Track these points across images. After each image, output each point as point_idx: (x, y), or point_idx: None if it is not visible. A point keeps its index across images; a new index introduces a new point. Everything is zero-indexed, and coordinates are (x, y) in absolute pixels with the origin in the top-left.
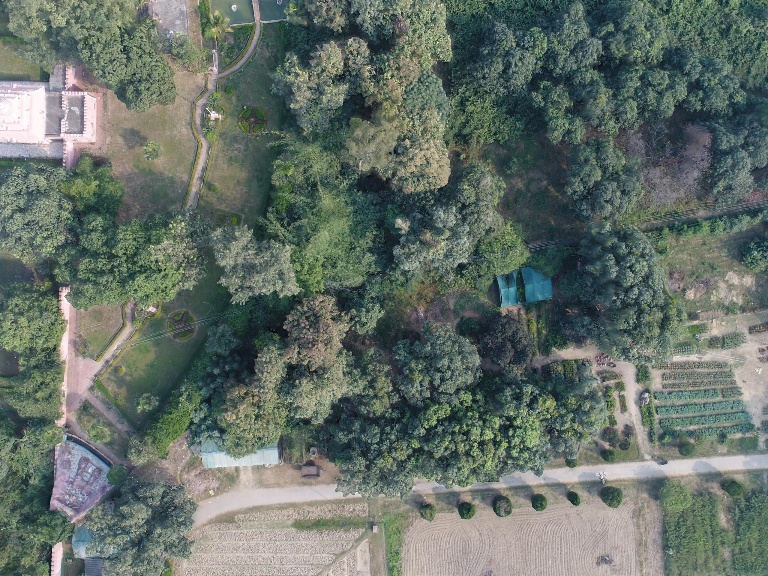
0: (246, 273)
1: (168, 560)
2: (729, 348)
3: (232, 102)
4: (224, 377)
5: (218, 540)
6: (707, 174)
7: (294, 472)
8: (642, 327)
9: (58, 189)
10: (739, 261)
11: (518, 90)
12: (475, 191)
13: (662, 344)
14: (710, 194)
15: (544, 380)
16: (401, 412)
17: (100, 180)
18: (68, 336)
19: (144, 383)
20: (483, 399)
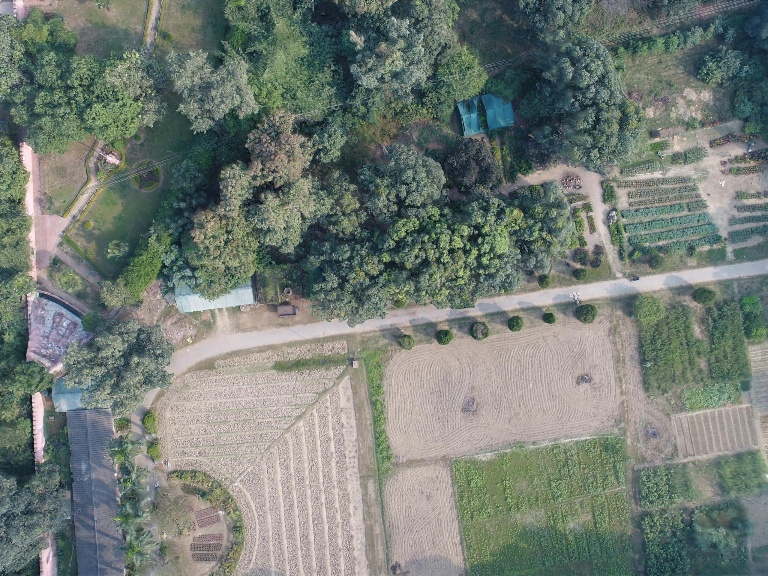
0: (204, 95)
1: (151, 411)
2: (691, 163)
3: None
4: (191, 212)
5: (199, 388)
6: None
7: (270, 315)
8: (601, 124)
9: (9, 33)
10: (695, 76)
11: None
12: (428, 8)
13: (622, 143)
14: (662, 10)
15: (511, 199)
16: (370, 232)
17: (52, 30)
18: (33, 194)
19: (113, 236)
20: (451, 213)
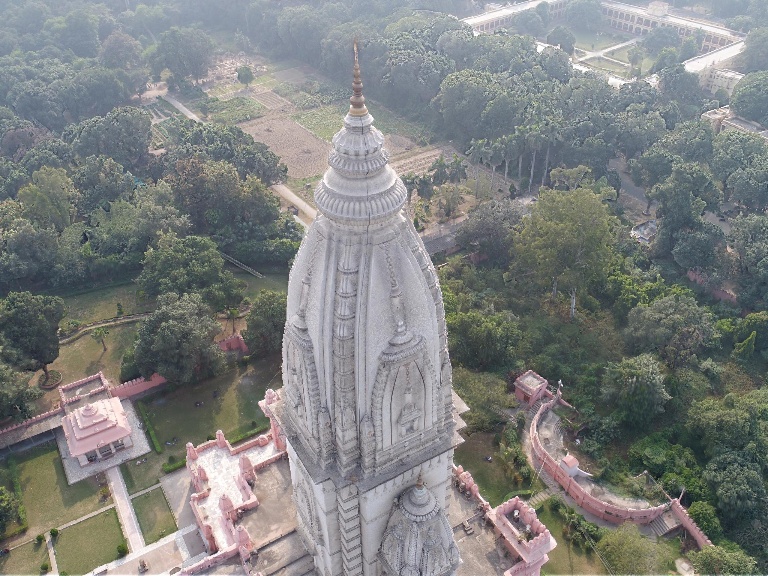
0: None
1: None
2: None
3: None
4: None
5: None
6: None
7: None
8: None
9: None
10: None
11: None
12: None
13: None
14: None
15: None
16: None
17: None
18: None
19: None
20: None
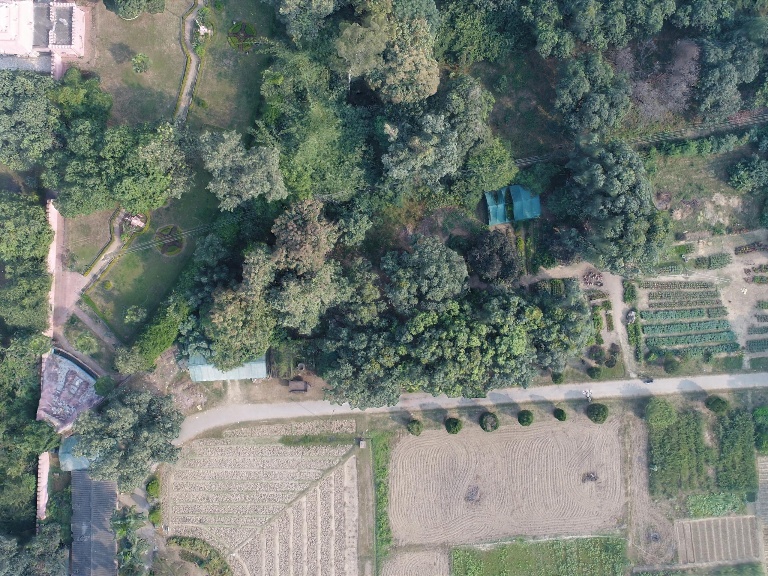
0: (234, 177)
1: (155, 475)
2: (715, 268)
3: (222, 18)
4: (212, 287)
5: (205, 455)
6: (695, 90)
7: (282, 388)
8: (629, 235)
9: (46, 95)
10: (726, 182)
11: (508, 5)
12: (464, 102)
13: (648, 254)
14: (698, 114)
15: (531, 295)
16: (389, 321)
17: (88, 91)
18: (55, 250)
19: (132, 298)
20: (470, 309)
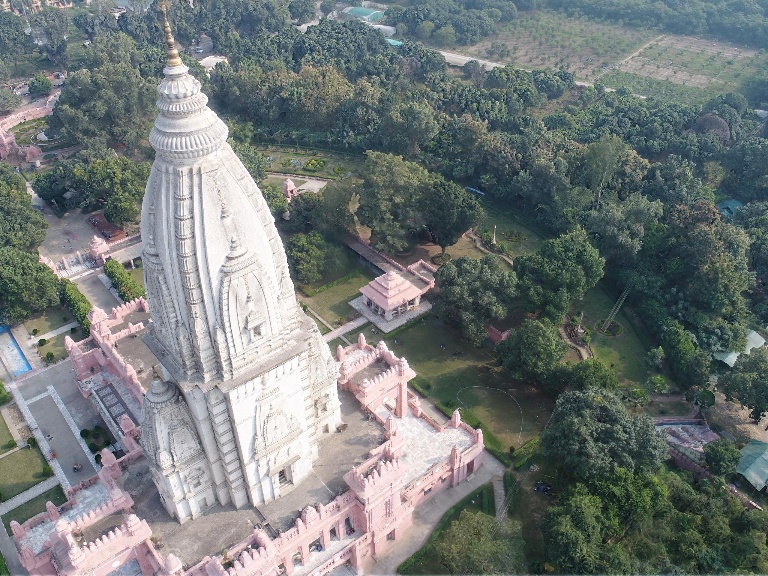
0: (629, 222)
1: None
2: None
3: None
4: None
5: None
6: None
7: None
8: None
9: None
10: None
11: None
12: None
13: None
14: None
15: None
16: None
17: None
18: None
19: (633, 369)
20: None
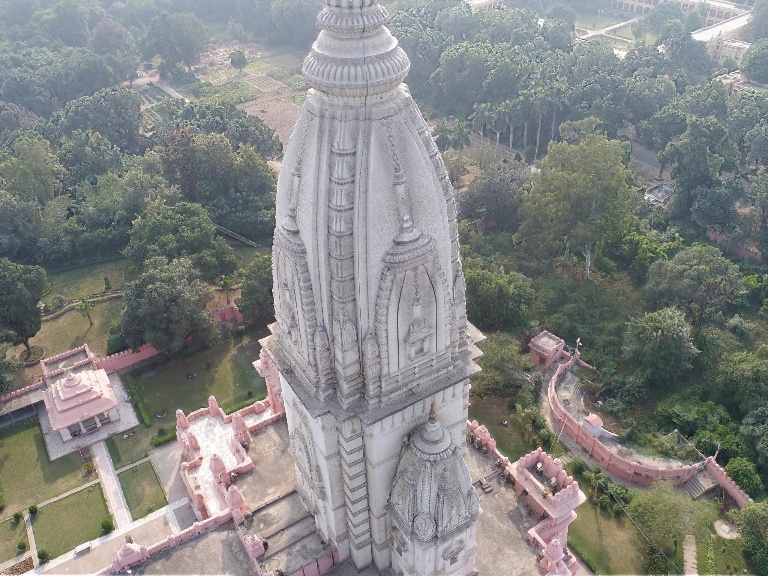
0: None
1: None
2: None
3: None
4: None
5: None
6: None
7: None
8: None
9: None
10: None
11: None
12: None
13: None
14: None
15: None
16: None
17: None
18: None
19: None
20: None
